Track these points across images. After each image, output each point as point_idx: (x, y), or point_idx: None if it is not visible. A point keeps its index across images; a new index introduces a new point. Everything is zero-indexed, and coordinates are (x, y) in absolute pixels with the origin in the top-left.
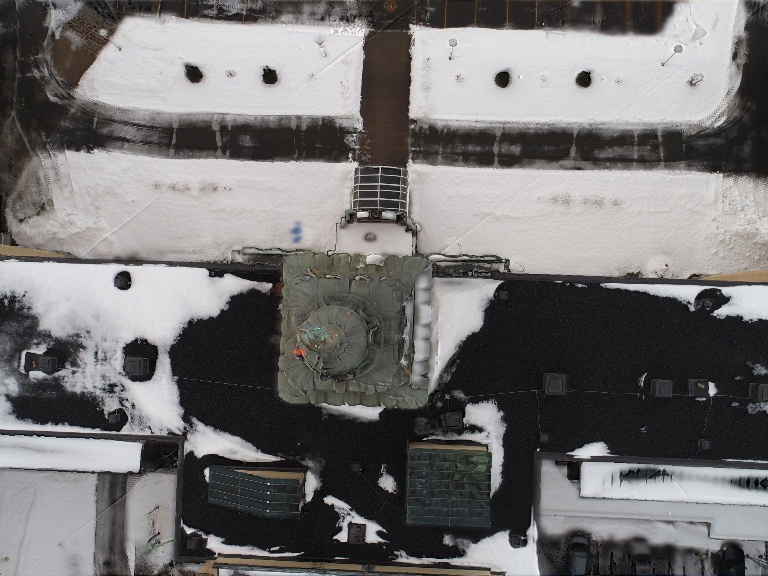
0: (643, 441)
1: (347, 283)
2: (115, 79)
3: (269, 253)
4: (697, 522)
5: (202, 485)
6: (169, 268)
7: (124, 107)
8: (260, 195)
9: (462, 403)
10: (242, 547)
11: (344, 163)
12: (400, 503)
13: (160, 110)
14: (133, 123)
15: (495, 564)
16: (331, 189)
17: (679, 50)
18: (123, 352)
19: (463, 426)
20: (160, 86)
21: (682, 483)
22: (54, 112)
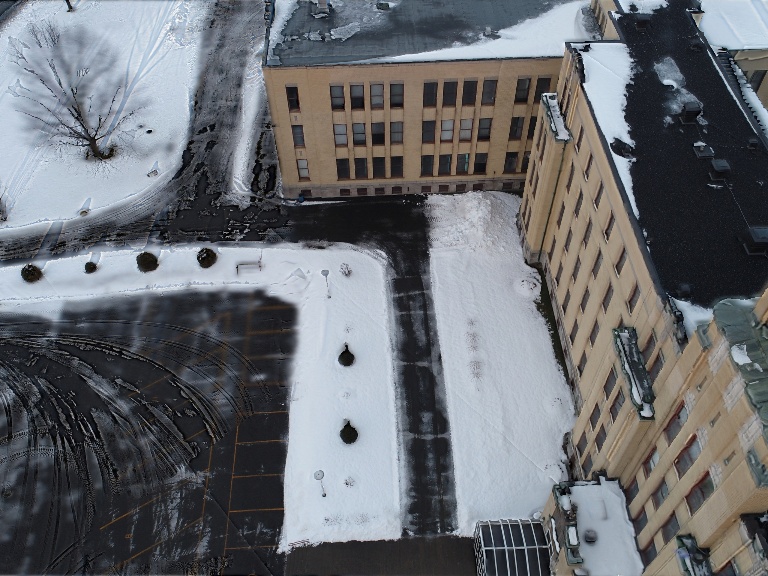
0: None
1: None
2: None
3: None
4: None
5: None
6: None
7: None
8: None
9: None
10: None
11: None
12: None
13: None
14: None
15: None
16: None
17: (327, 272)
18: None
19: None
20: None
21: None
22: None
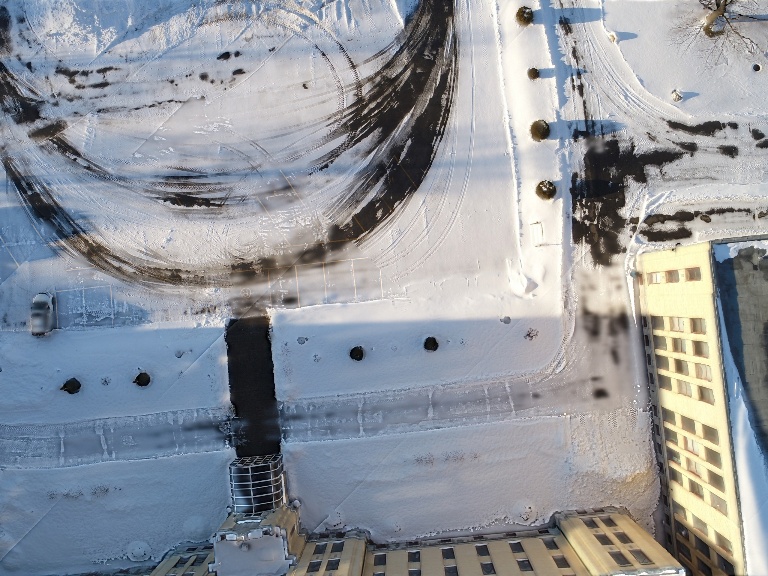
0: None
1: None
2: None
3: None
4: None
5: None
6: None
7: (12, 424)
8: (149, 490)
9: None
10: None
11: (222, 451)
12: None
13: (45, 423)
14: (22, 438)
15: None
16: (213, 476)
17: (508, 322)
18: None
19: None
20: (42, 401)
21: None
22: None
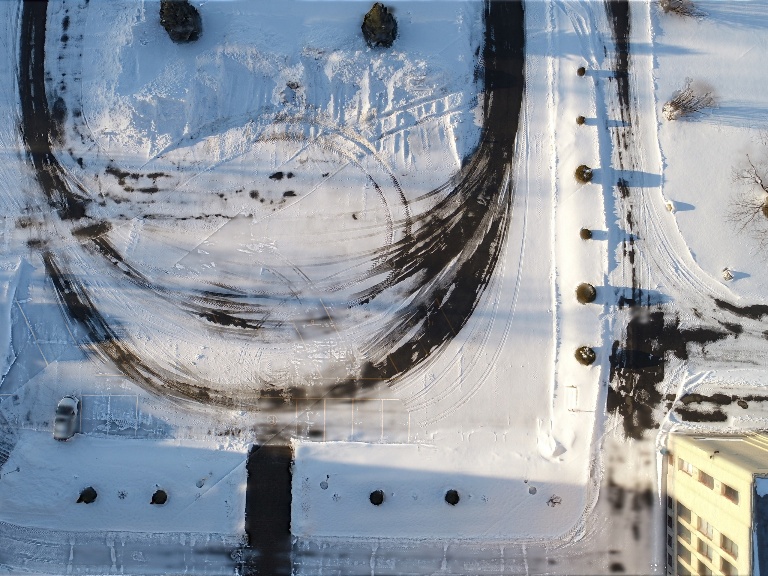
0: None
1: None
2: (14, 500)
3: None
4: None
5: None
6: None
7: (23, 526)
8: None
9: None
10: None
11: None
12: None
13: (57, 529)
14: (32, 540)
15: None
16: None
17: (533, 492)
18: None
19: None
20: (57, 506)
21: None
22: None
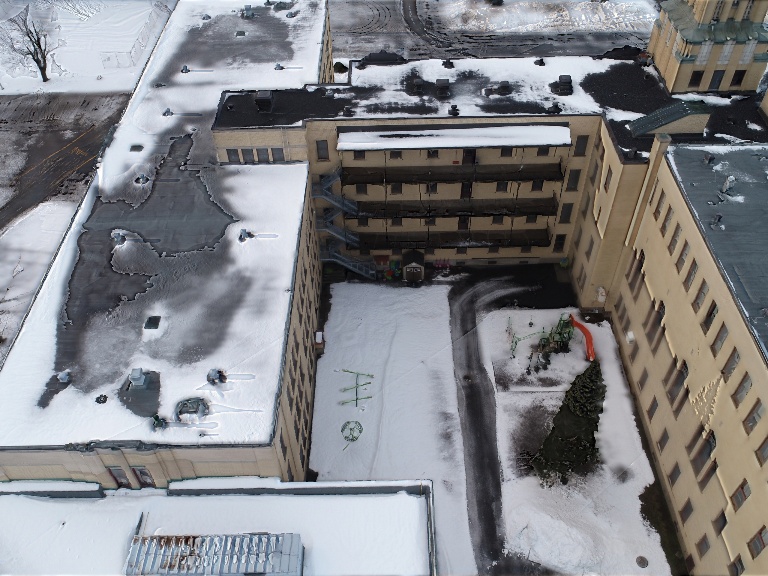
0: None
1: None
2: None
3: None
4: None
5: (626, 131)
6: None
7: None
8: None
9: None
10: None
11: None
12: None
13: None
14: None
15: None
16: None
17: None
18: (549, 86)
19: None
20: None
21: None
22: None
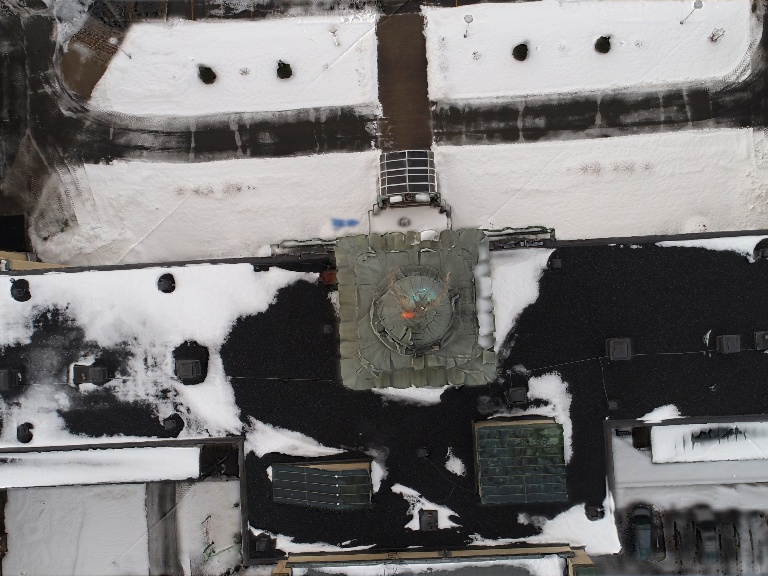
0: (714, 400)
1: (416, 255)
2: (128, 87)
3: (309, 244)
4: (760, 483)
5: (266, 485)
6: (213, 266)
7: (139, 115)
8: (285, 191)
9: (524, 377)
10: (312, 544)
11: (367, 151)
12: (470, 485)
13: (176, 115)
14: (150, 130)
15: (573, 539)
16: (356, 179)
17: (699, 6)
18: (173, 356)
19: (528, 401)
20: (174, 90)
21: (756, 440)
22: (69, 126)
